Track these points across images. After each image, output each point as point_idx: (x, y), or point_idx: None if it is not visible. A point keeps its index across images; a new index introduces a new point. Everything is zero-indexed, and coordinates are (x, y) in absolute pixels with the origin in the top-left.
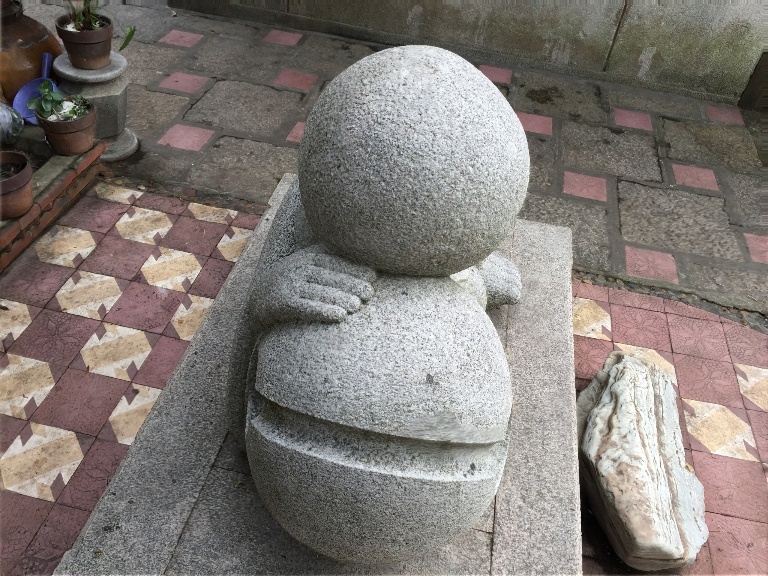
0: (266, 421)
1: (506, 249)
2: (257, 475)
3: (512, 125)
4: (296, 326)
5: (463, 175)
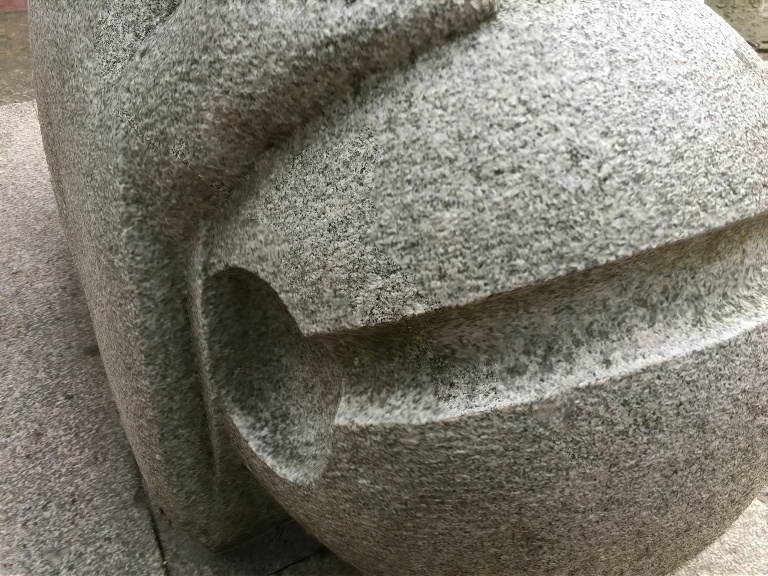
0: (386, 395)
1: None
2: (424, 539)
3: None
4: (362, 97)
5: None
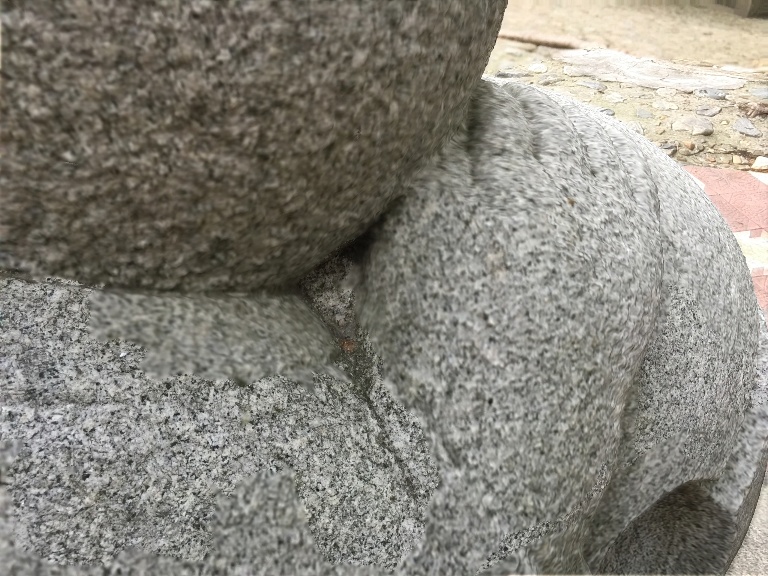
0: None
1: None
2: None
3: None
4: None
5: None
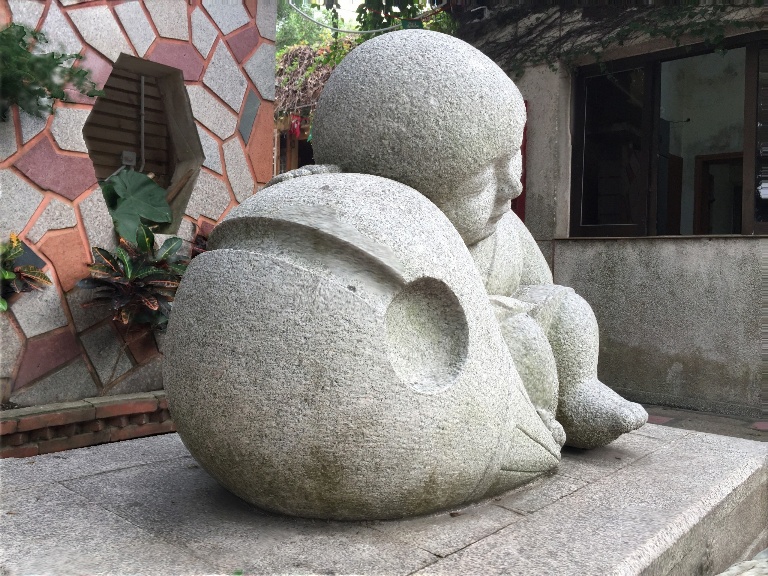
0: None
1: (666, 439)
2: None
3: (489, 62)
4: None
5: (411, 60)
